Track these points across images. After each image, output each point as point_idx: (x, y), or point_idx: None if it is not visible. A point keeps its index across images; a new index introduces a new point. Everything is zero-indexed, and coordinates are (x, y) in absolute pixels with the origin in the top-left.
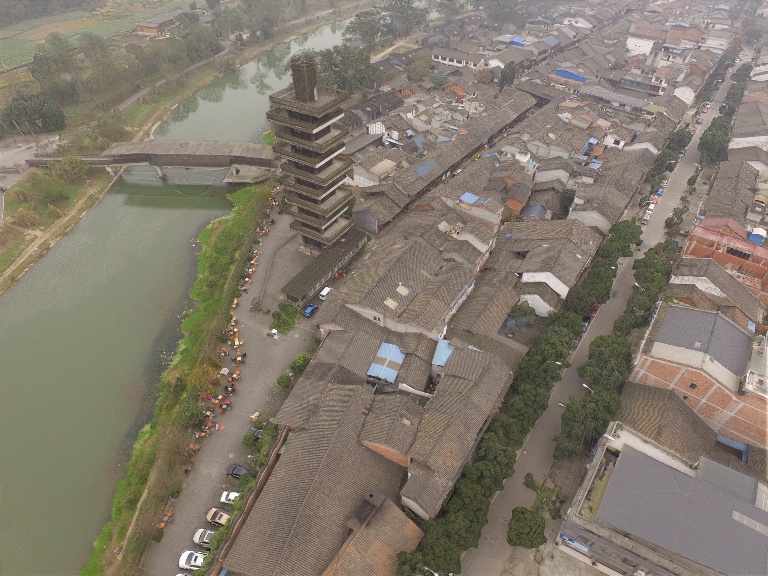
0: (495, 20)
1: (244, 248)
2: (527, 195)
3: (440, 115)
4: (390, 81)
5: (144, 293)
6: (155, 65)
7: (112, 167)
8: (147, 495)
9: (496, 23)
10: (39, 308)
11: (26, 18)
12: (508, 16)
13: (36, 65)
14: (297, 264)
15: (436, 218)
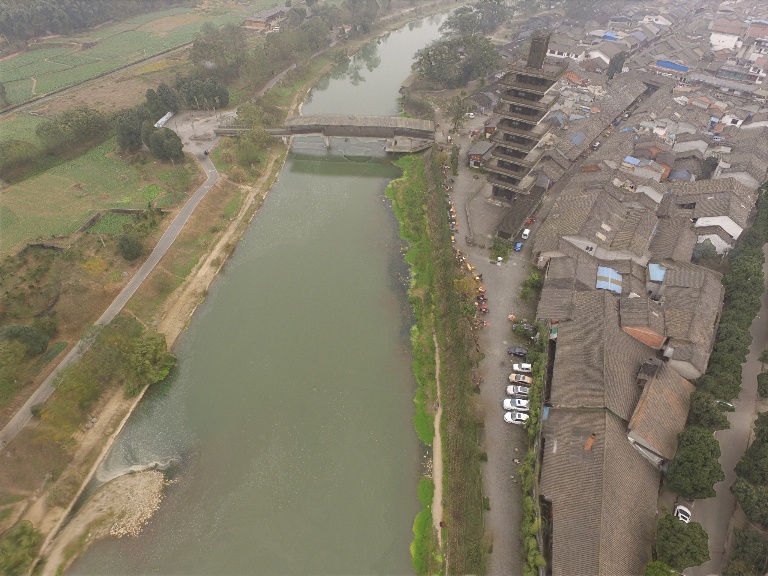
0: (573, 18)
1: (432, 202)
2: (674, 161)
3: (570, 96)
4: None
5: (361, 234)
6: (287, 53)
7: (287, 137)
8: (440, 371)
9: (577, 20)
10: (280, 243)
11: (138, 13)
12: (587, 14)
13: (198, 51)
14: (491, 212)
15: (609, 176)
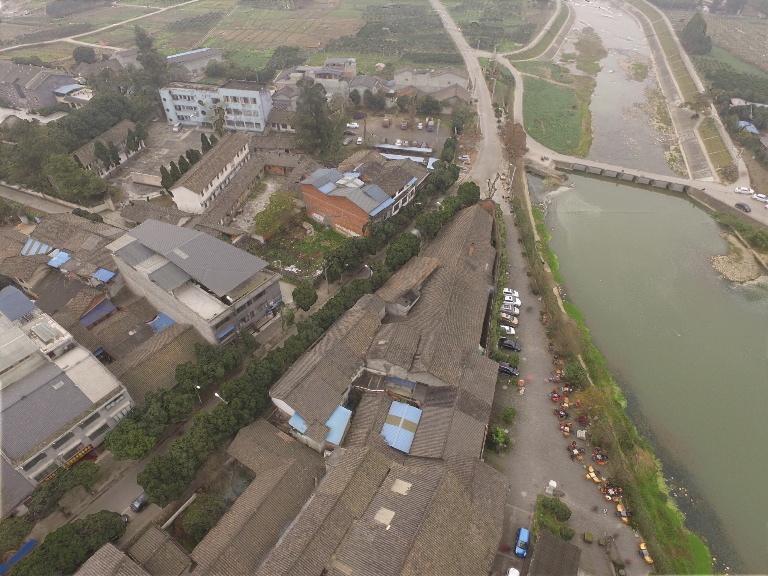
0: None
1: None
2: None
3: None
4: None
5: None
6: None
7: None
8: None
9: None
10: None
11: None
12: None
13: None
14: None
15: None
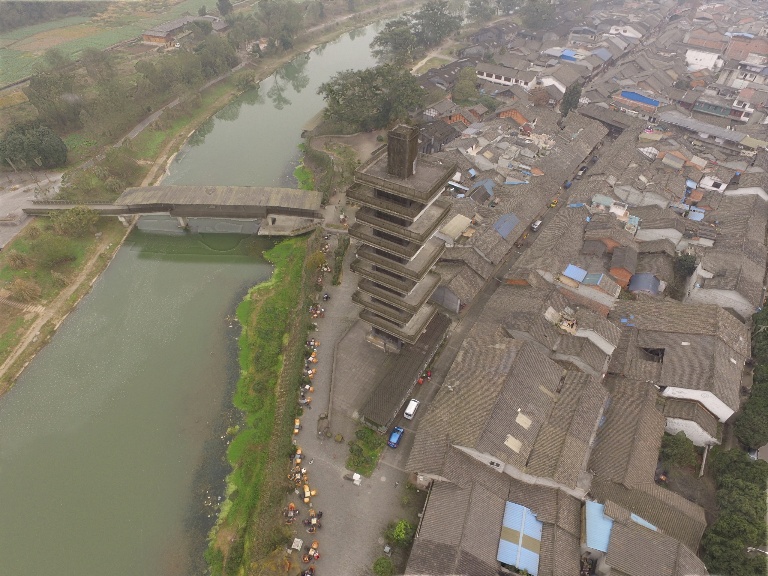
0: (531, 27)
1: (294, 332)
2: (636, 262)
3: (507, 151)
4: (436, 104)
5: (175, 399)
6: (168, 84)
7: (126, 217)
8: None
9: (535, 31)
10: (43, 425)
11: (20, 25)
12: (547, 23)
13: (33, 89)
14: (368, 363)
15: (540, 303)
